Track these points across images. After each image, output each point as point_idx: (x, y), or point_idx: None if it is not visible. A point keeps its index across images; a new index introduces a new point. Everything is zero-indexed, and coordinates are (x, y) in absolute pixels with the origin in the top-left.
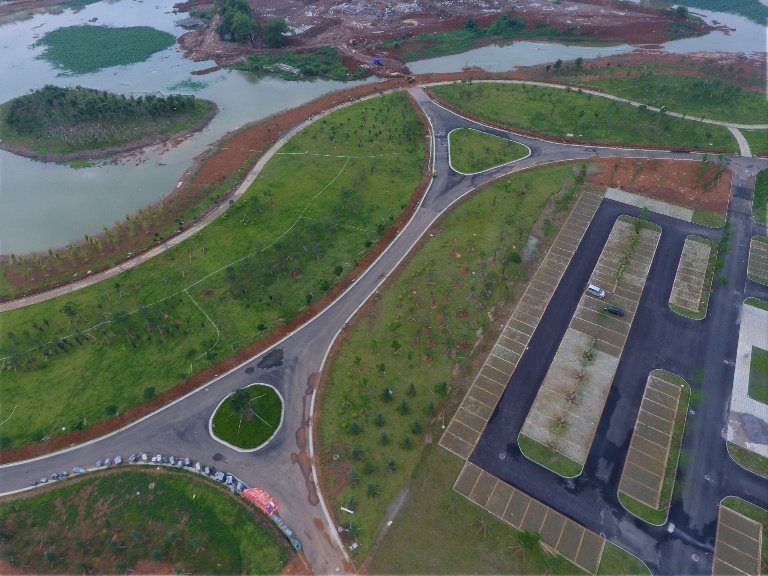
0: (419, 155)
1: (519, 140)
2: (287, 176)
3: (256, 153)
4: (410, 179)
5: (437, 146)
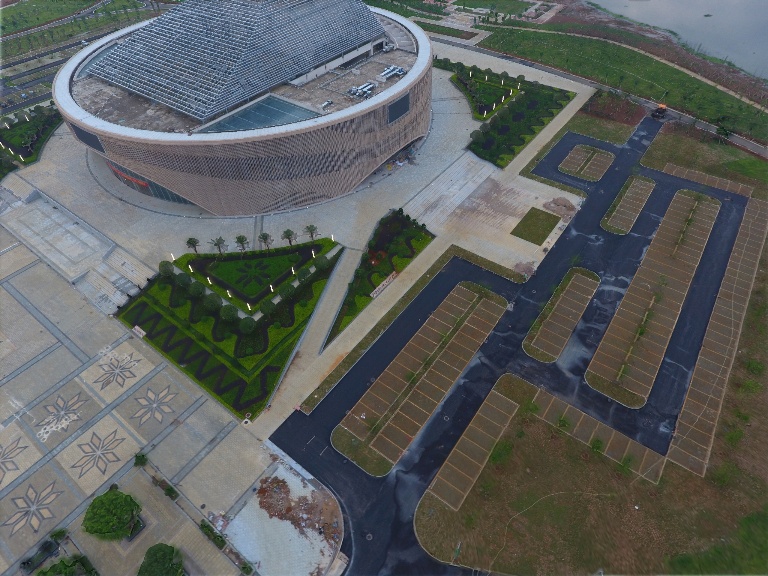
0: (83, 6)
1: (146, 2)
2: (5, 12)
3: (2, 5)
4: (63, 14)
5: (100, 4)
